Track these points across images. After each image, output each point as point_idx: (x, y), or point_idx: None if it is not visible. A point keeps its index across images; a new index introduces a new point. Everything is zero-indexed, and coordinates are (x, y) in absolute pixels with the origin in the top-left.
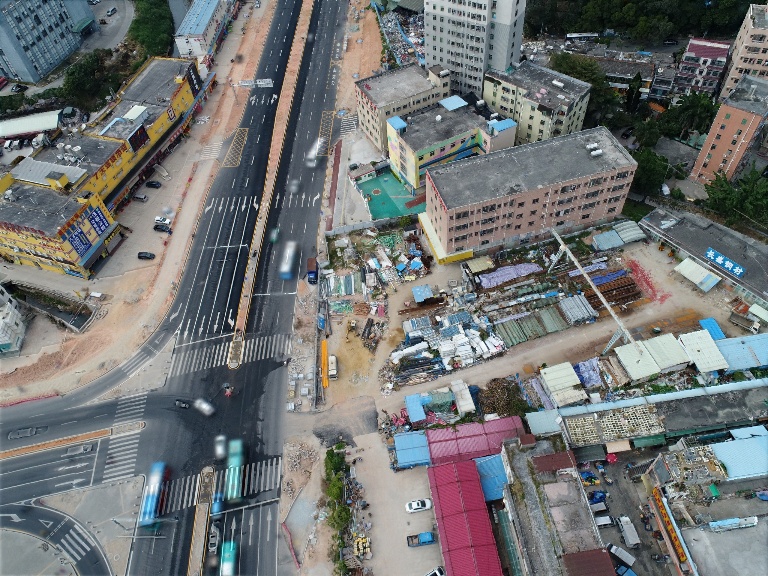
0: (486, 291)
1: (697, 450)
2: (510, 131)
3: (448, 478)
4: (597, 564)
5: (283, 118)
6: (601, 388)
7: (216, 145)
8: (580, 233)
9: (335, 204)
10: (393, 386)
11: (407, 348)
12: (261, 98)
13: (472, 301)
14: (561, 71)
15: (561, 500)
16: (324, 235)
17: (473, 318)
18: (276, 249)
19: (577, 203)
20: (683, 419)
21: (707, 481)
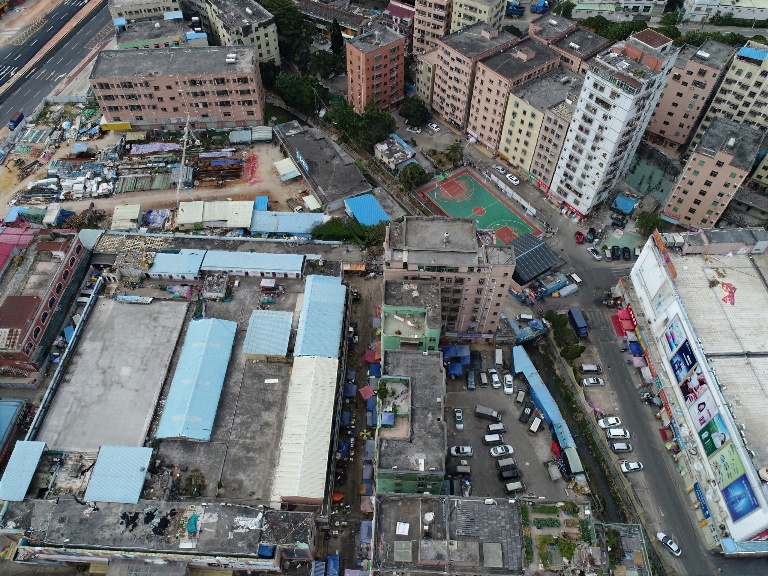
0: (131, 156)
1: None
2: (201, 42)
3: None
4: (24, 303)
5: (79, 17)
6: (157, 228)
7: (16, 28)
8: (229, 130)
9: (71, 82)
10: (15, 202)
11: (41, 180)
12: (74, 0)
13: (113, 159)
14: (265, 4)
15: (43, 272)
16: (43, 100)
17: (104, 170)
18: (4, 104)
19: (212, 99)
20: None
21: (139, 274)
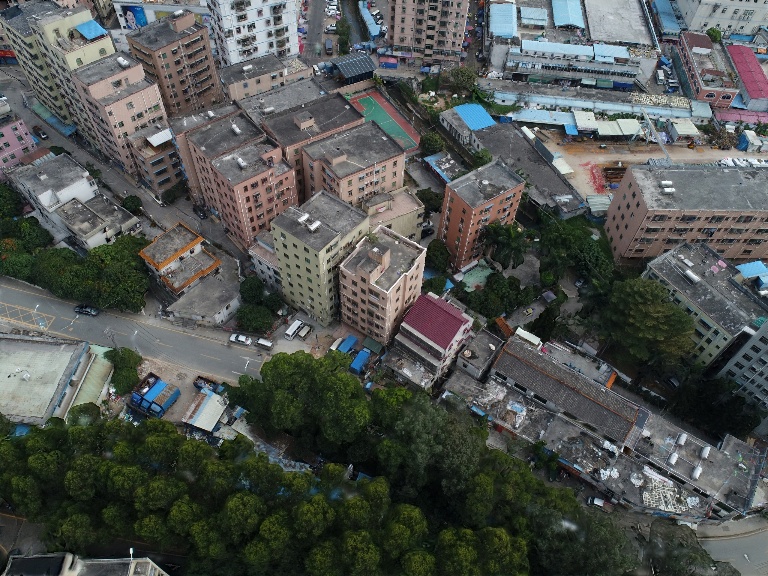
0: None
1: (639, 56)
2: None
3: (767, 93)
4: None
5: None
6: None
7: None
8: None
9: None
10: None
11: None
12: None
13: None
14: None
15: None
16: None
17: None
18: None
19: None
20: (617, 95)
21: None
